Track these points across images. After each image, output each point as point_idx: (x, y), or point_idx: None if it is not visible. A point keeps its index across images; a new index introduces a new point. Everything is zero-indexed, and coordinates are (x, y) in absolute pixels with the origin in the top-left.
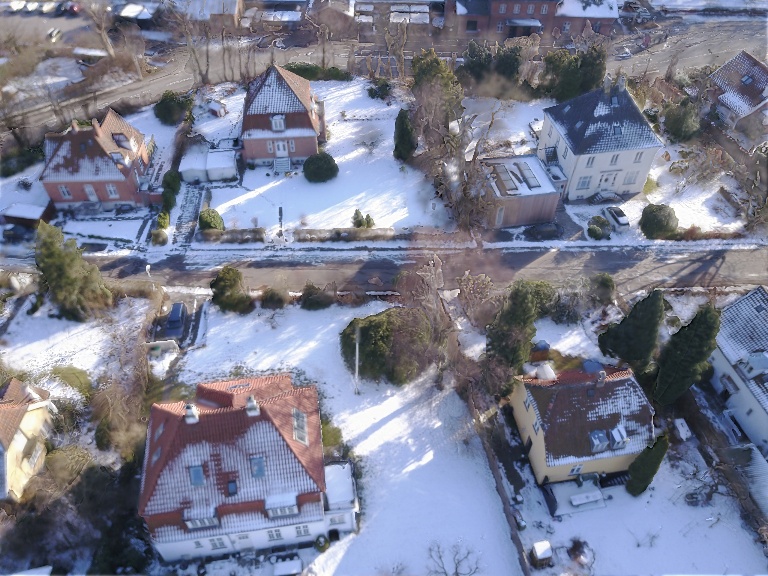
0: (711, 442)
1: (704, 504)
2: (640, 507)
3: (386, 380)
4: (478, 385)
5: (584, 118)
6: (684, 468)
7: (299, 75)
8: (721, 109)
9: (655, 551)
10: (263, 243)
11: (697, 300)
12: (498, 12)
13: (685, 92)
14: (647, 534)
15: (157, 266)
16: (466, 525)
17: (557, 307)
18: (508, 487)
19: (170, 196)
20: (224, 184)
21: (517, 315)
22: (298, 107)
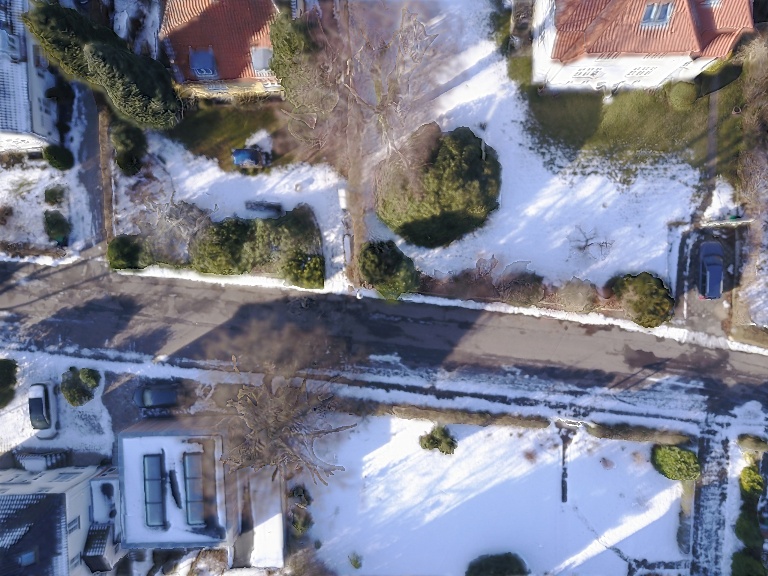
0: (98, 2)
1: None
2: None
3: None
4: (335, 124)
5: (13, 567)
6: None
7: None
8: None
9: None
10: (592, 421)
11: (3, 233)
12: None
13: None
14: None
15: (746, 392)
16: None
17: None
18: None
19: (751, 529)
20: (659, 572)
21: None
22: None
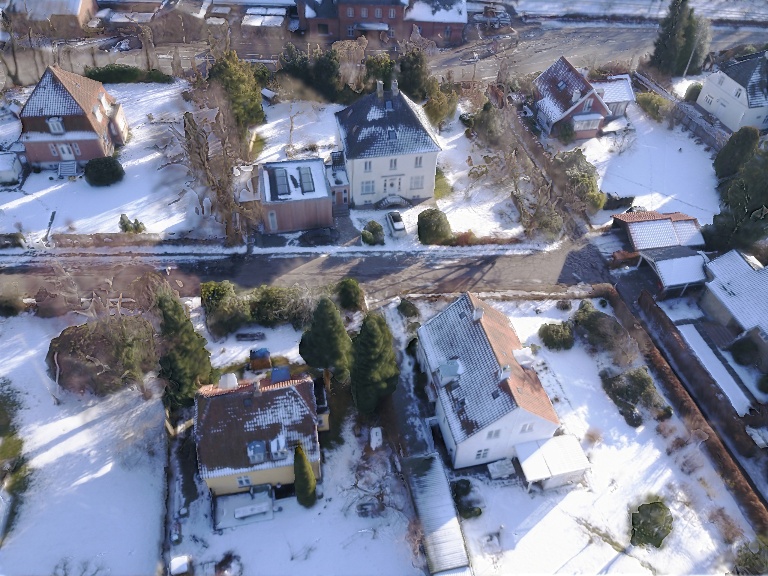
0: (398, 451)
1: (375, 515)
2: (308, 519)
3: (92, 390)
4: None
5: (359, 122)
6: (368, 478)
7: (118, 77)
8: (540, 114)
9: (307, 564)
10: (22, 248)
11: None
12: (347, 16)
13: (510, 97)
14: (303, 547)
15: None
16: (118, 540)
17: (296, 314)
18: (179, 500)
19: None
20: (3, 188)
21: (168, 323)
22: (76, 109)
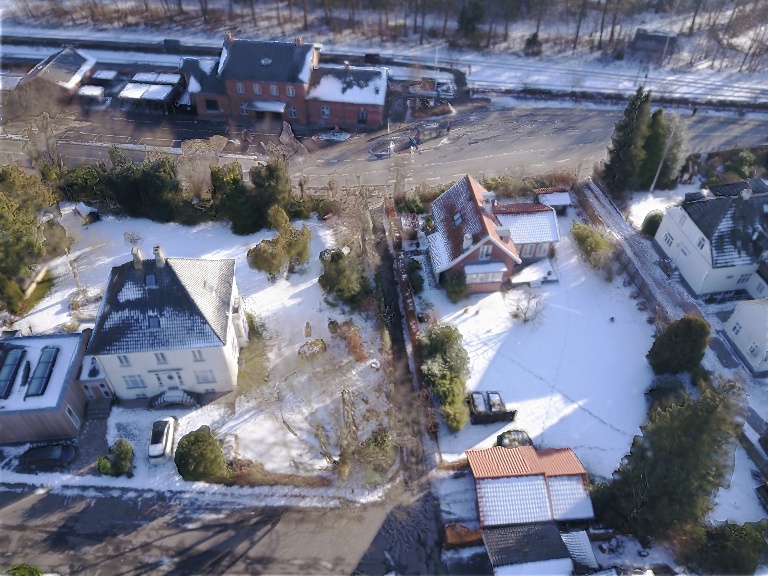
0: None
1: None
2: None
3: None
4: None
5: None
6: None
7: None
8: None
9: None
10: None
11: None
12: (237, 92)
13: (401, 222)
14: None
15: None
16: None
17: None
18: None
19: None
20: None
21: None
22: None
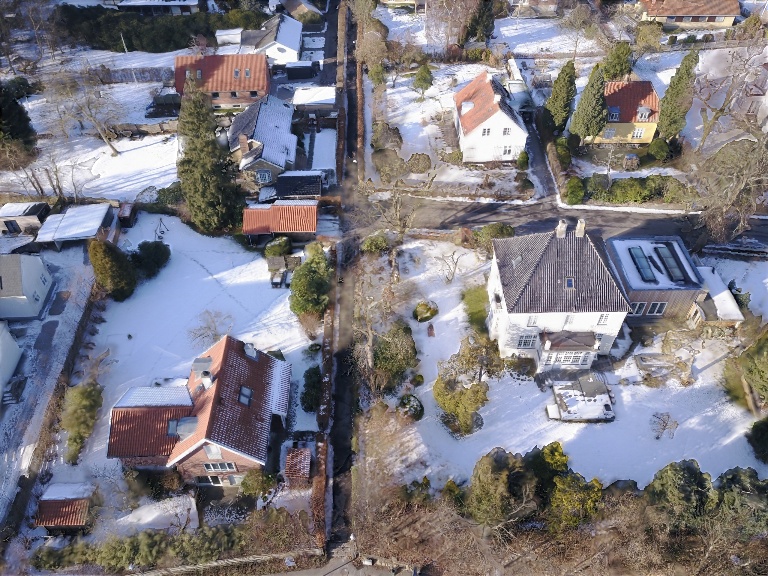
0: None
1: None
2: None
3: None
4: (671, 154)
5: None
6: None
7: None
8: None
9: None
10: None
11: (491, 192)
12: None
13: None
14: None
15: None
16: None
17: None
18: None
19: None
20: None
21: None
22: None
